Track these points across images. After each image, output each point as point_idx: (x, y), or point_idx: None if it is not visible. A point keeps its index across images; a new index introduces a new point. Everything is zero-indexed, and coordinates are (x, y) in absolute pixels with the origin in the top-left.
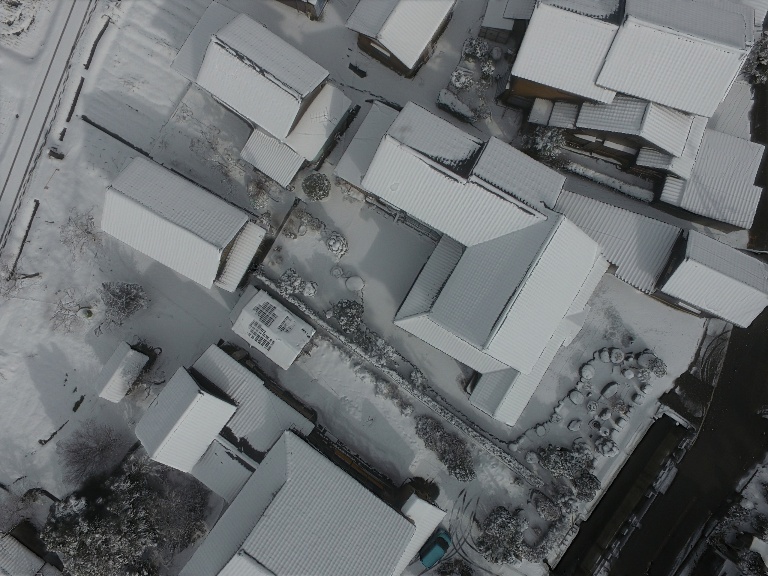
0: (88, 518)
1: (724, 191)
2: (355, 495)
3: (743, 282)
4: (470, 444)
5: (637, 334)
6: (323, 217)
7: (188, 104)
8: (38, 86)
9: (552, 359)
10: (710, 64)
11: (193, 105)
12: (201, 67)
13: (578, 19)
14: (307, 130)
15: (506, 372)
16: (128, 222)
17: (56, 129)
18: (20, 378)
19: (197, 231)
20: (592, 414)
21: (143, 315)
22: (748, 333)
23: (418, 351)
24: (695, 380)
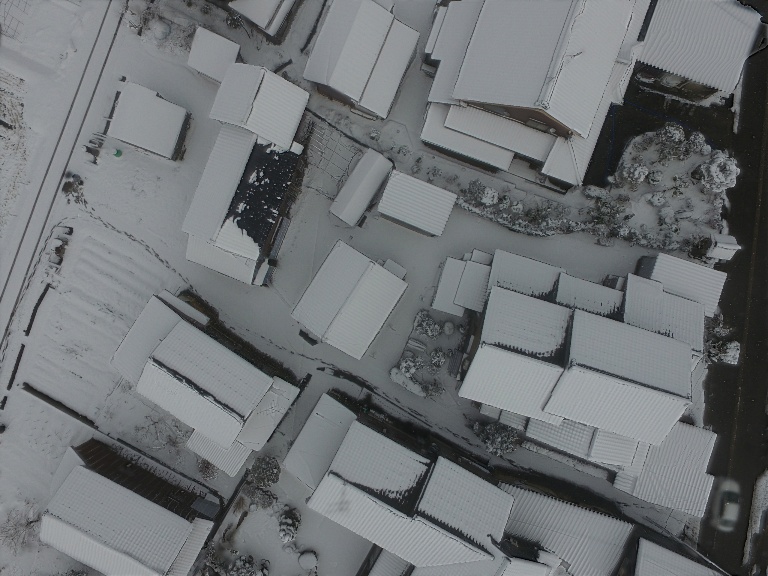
0: None
1: (676, 480)
2: None
3: None
4: None
5: None
6: (275, 489)
7: None
8: None
9: None
10: (656, 406)
11: None
12: (140, 380)
13: (523, 359)
14: (253, 425)
15: None
16: (67, 540)
17: None
18: None
19: (138, 555)
20: None
21: None
22: None
23: None
24: None
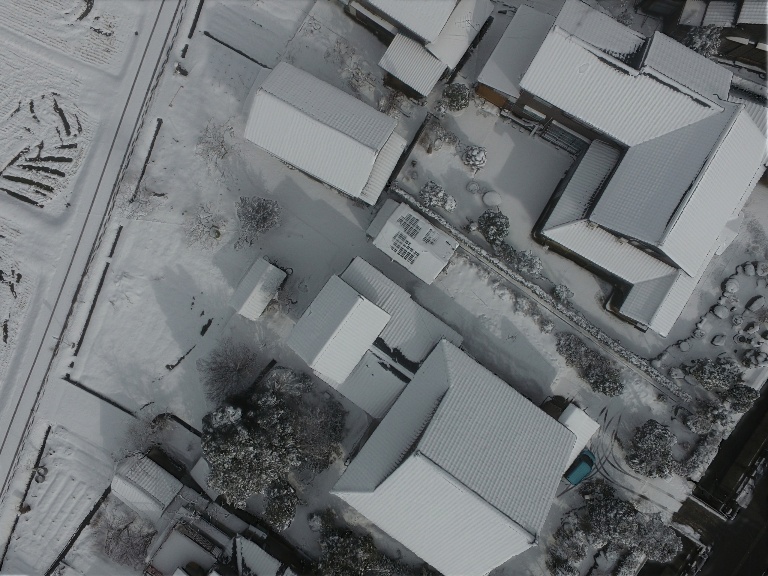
0: (247, 428)
1: None
2: (516, 403)
3: None
4: (612, 361)
5: None
6: (457, 132)
7: (315, 17)
8: (159, 1)
9: None
10: None
11: (321, 18)
12: None
13: None
14: None
15: (661, 280)
16: (276, 127)
17: (178, 45)
18: (146, 302)
19: (351, 134)
20: (737, 329)
21: (273, 235)
22: None
23: (555, 268)
24: None
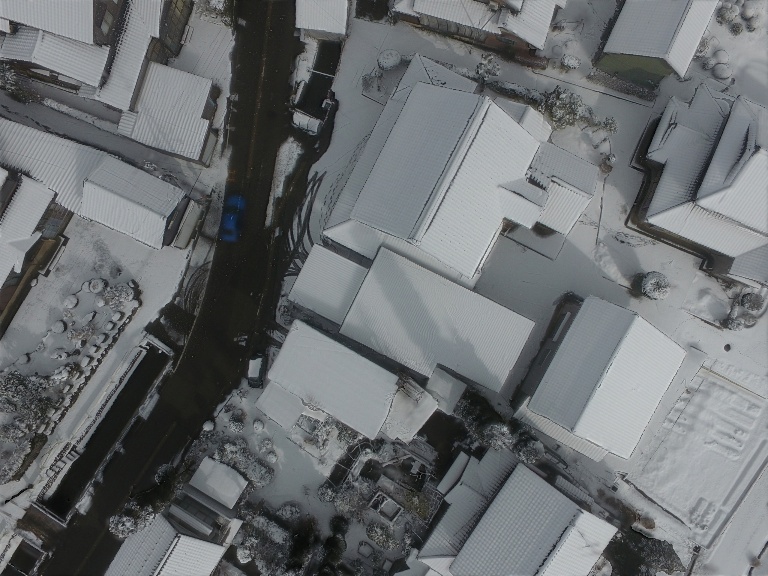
0: None
1: (173, 123)
2: None
3: (138, 203)
4: None
5: (124, 266)
6: None
7: None
8: None
9: (2, 284)
10: None
11: None
12: None
13: None
14: None
15: None
16: None
17: None
18: None
19: None
20: (74, 342)
21: None
22: (227, 264)
23: None
24: (179, 309)
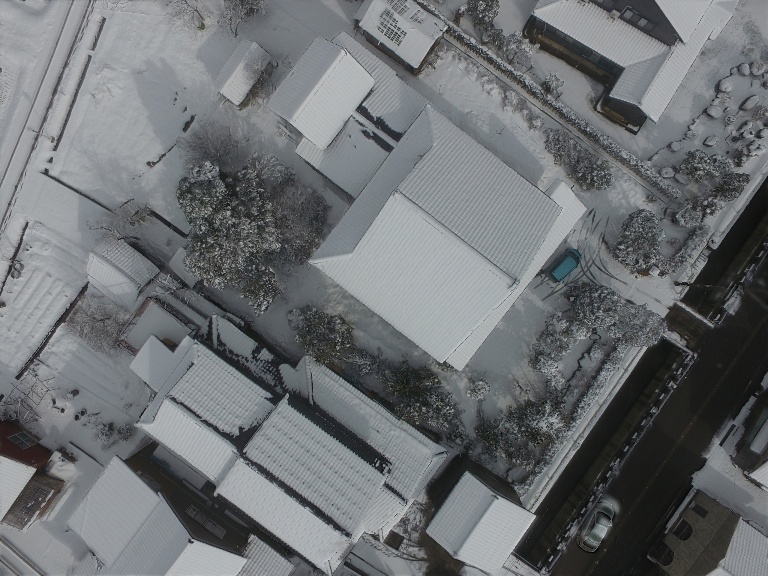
0: None
1: None
2: (500, 170)
3: None
4: (601, 161)
5: None
6: None
7: None
8: None
9: (699, 51)
10: None
11: None
12: None
13: None
14: None
15: (652, 60)
16: None
17: None
18: (128, 96)
19: None
20: (729, 129)
21: (258, 28)
22: None
23: (546, 68)
24: None
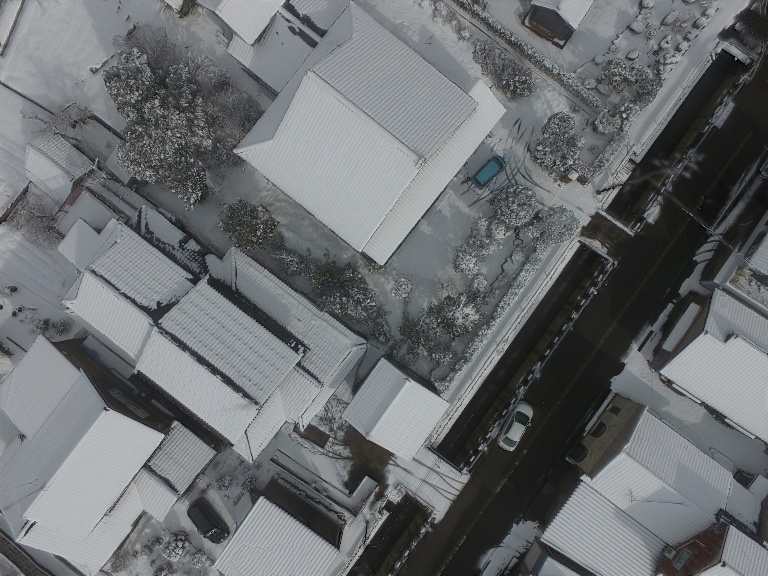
0: None
1: None
2: (419, 64)
3: None
4: None
5: None
6: None
7: None
8: None
9: None
10: None
11: None
12: None
13: None
14: None
15: None
16: None
17: None
18: (72, 4)
19: None
20: (651, 44)
21: None
22: None
23: None
24: (755, 16)
